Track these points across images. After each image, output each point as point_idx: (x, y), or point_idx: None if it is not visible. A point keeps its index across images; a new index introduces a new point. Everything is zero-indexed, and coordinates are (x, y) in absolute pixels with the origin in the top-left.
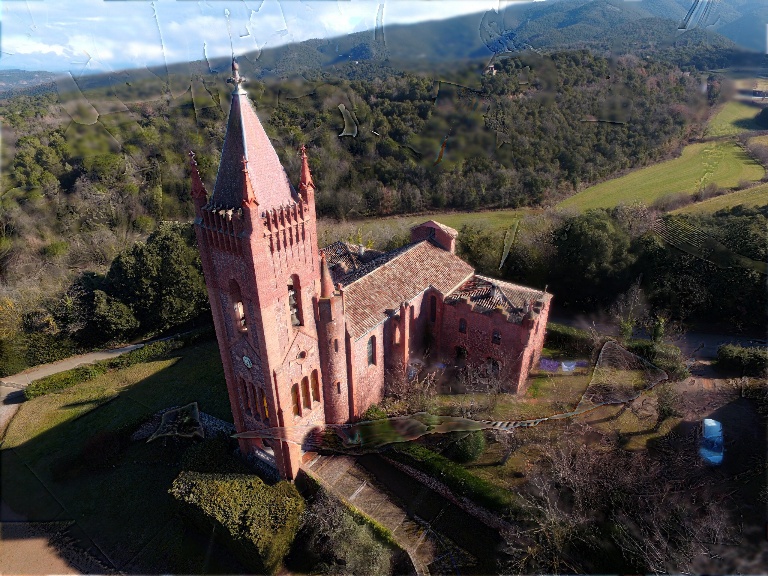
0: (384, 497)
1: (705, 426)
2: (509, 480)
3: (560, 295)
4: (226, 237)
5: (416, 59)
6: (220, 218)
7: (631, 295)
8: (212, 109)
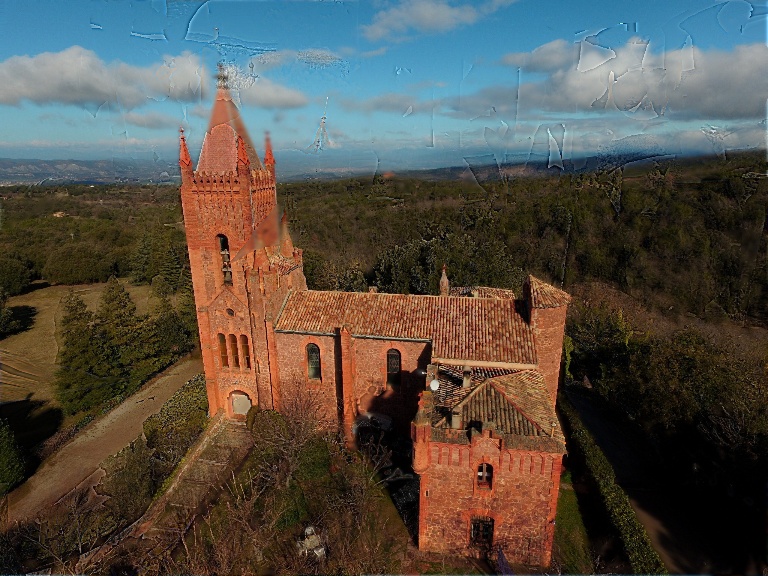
0: None
1: None
2: (233, 572)
3: None
4: None
5: None
6: None
7: None
8: None
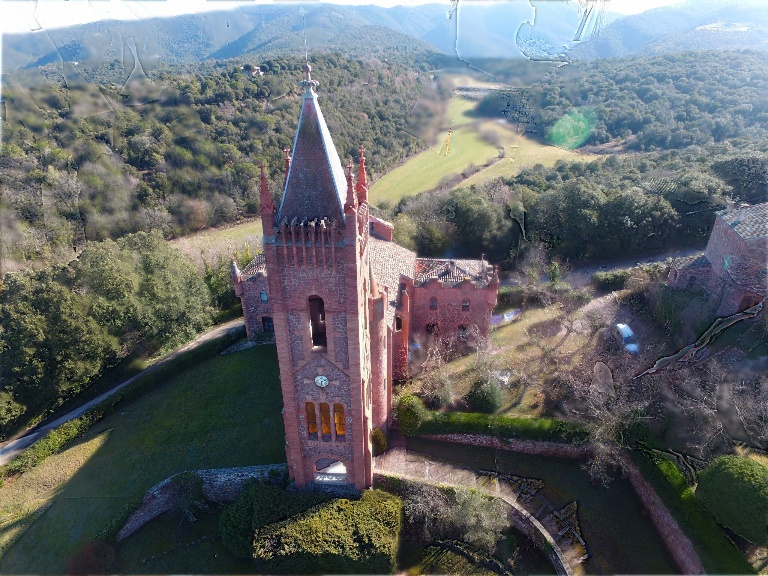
0: (449, 467)
1: (620, 329)
2: (531, 413)
3: None
4: (315, 250)
5: (477, 62)
6: (311, 231)
7: (509, 253)
8: None
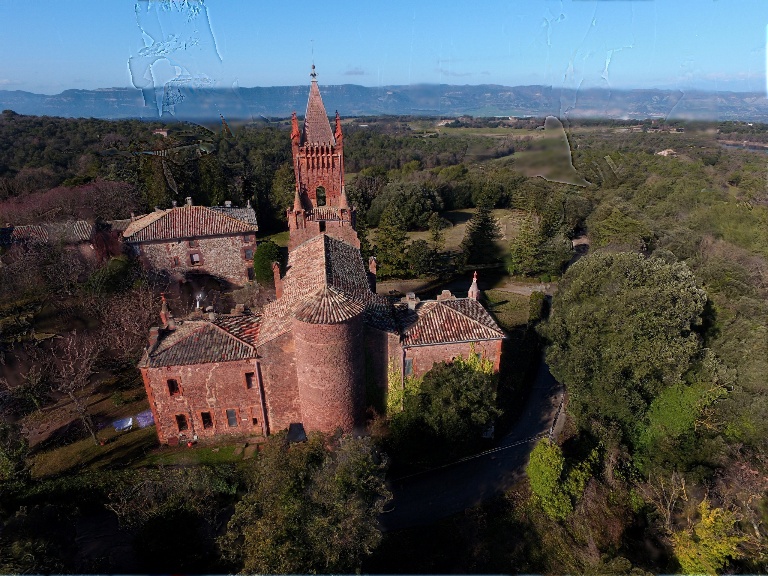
0: None
1: None
2: None
3: None
4: None
5: None
6: None
7: None
8: None
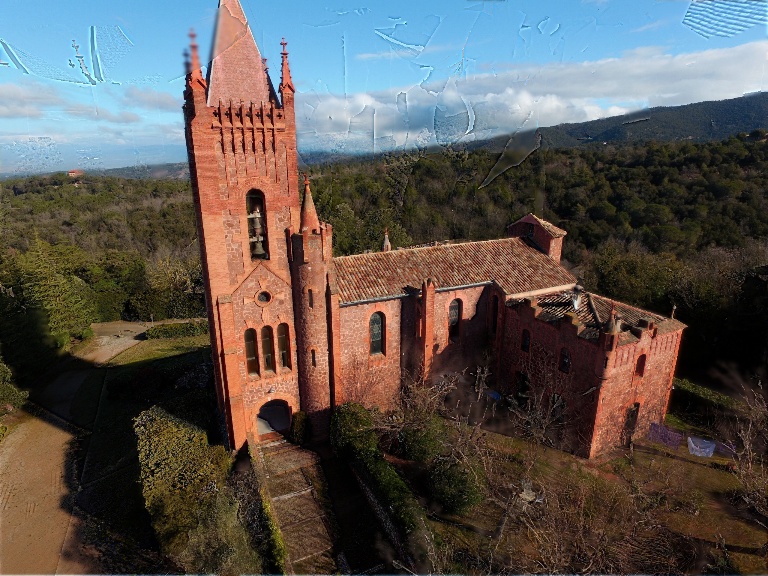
0: (319, 514)
1: None
2: None
3: (746, 362)
4: None
5: None
6: None
7: None
8: (390, 138)
